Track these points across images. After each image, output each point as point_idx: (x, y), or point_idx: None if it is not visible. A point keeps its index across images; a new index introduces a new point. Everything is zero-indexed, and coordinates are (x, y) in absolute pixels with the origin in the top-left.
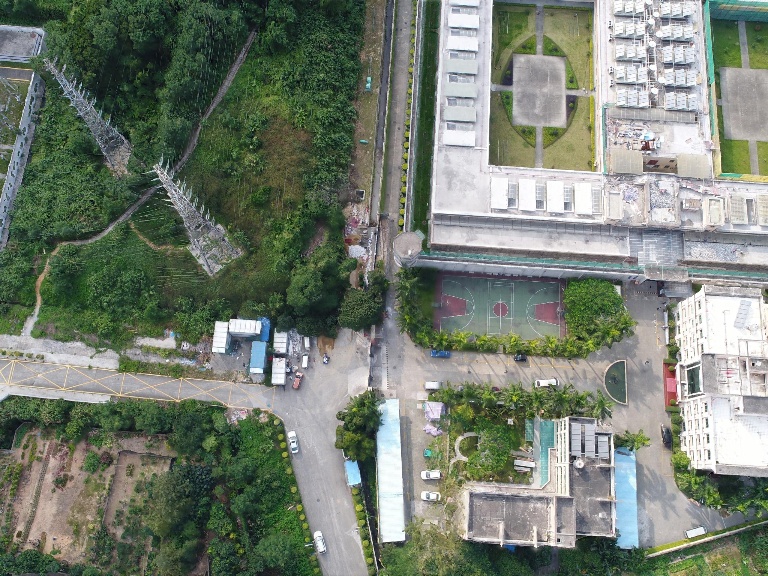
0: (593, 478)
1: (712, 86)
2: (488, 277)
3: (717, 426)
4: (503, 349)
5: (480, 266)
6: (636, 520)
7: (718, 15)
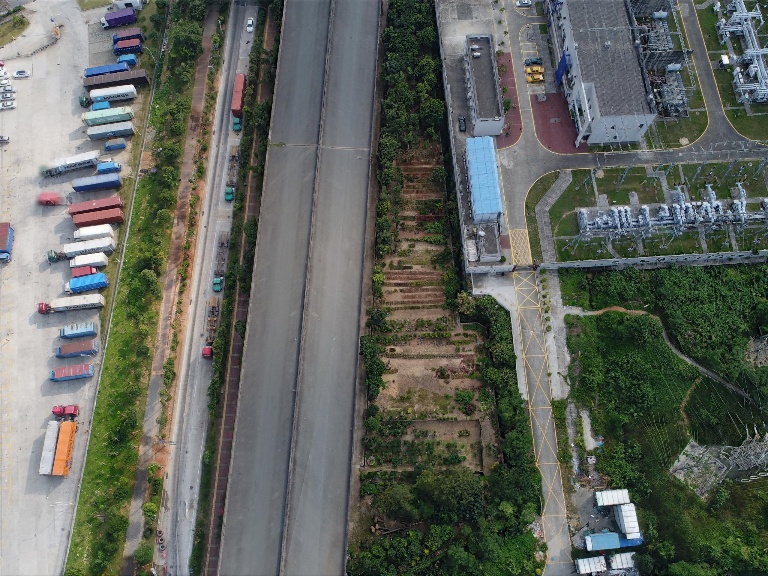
0: None
1: None
2: None
3: None
4: None
5: None
6: None
7: None
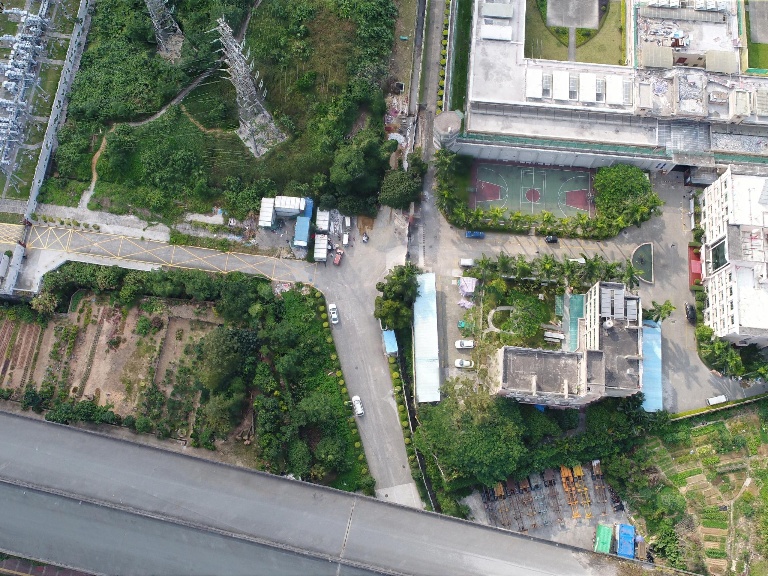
0: (621, 338)
1: None
2: (521, 165)
3: (741, 293)
4: (535, 231)
5: (515, 150)
6: (661, 386)
7: None
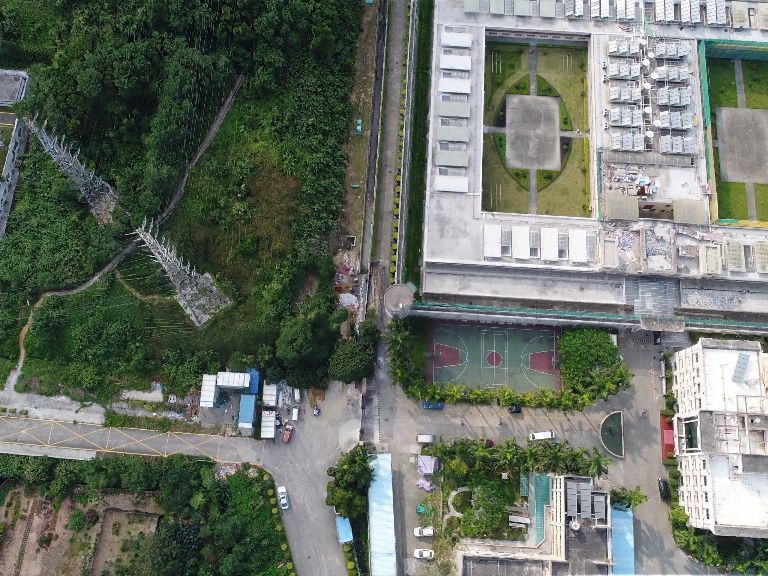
0: (589, 539)
1: (708, 129)
2: (481, 325)
3: (716, 485)
4: (497, 400)
5: (473, 316)
6: None
7: (714, 54)
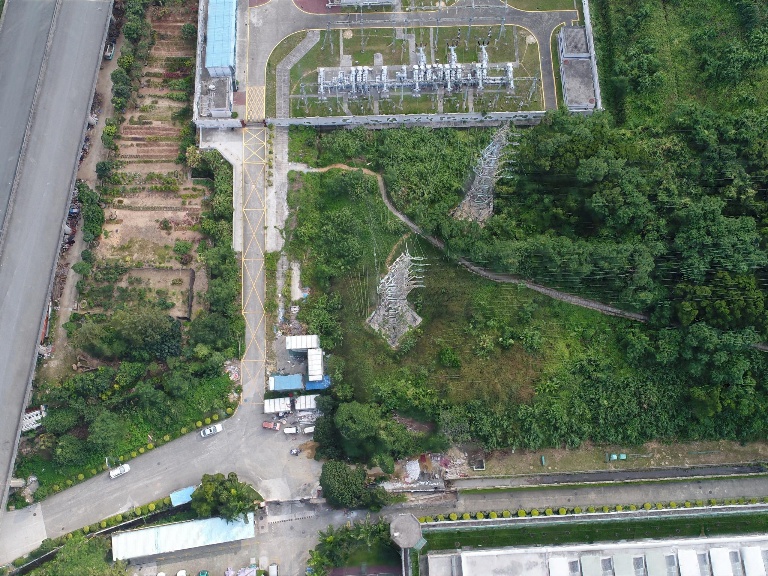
0: None
1: None
2: None
3: None
4: None
5: None
6: None
7: None
